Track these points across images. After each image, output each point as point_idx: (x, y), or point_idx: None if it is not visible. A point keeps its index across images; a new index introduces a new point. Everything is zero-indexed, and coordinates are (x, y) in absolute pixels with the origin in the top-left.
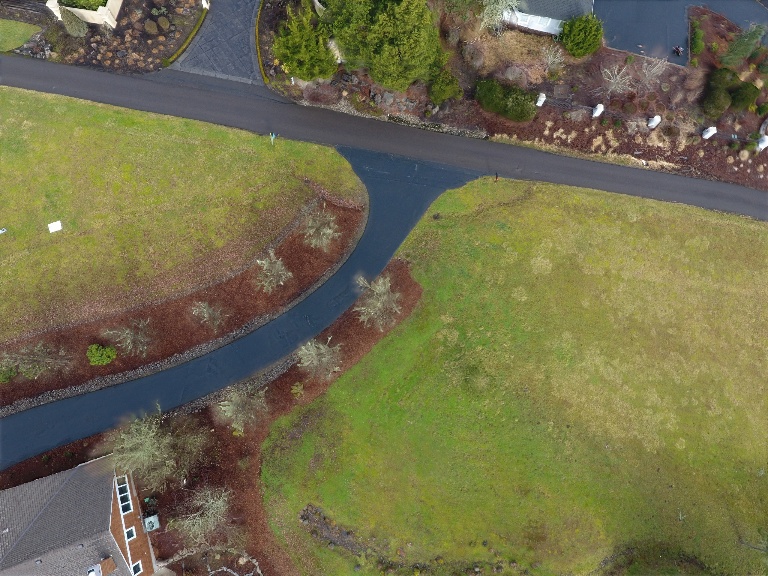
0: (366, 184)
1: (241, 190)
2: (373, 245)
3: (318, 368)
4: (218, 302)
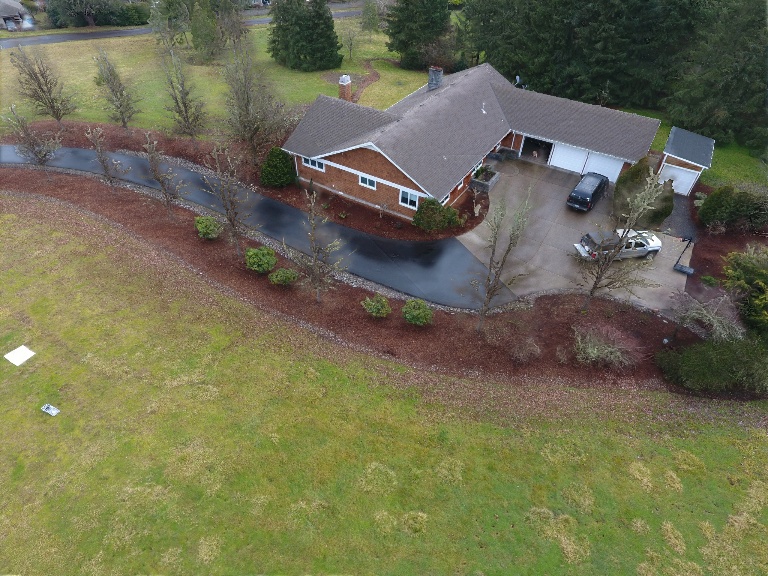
0: None
1: None
2: None
3: (141, 138)
4: (98, 198)
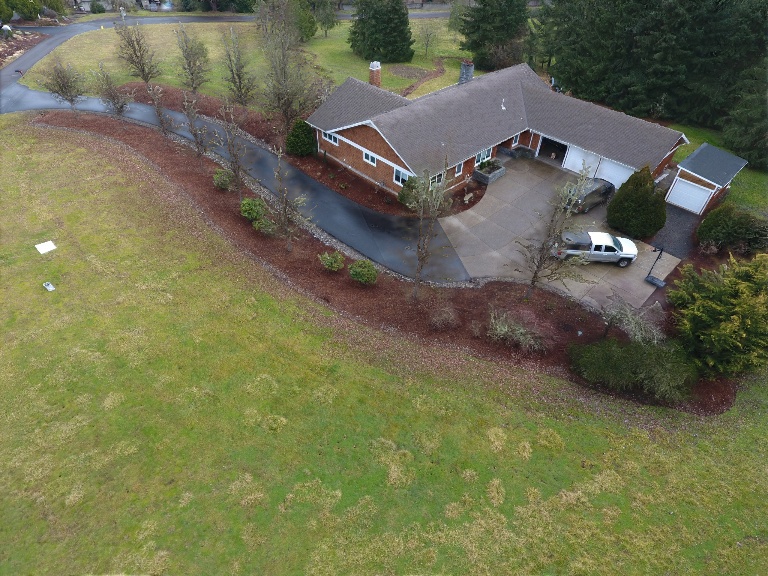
0: (14, 111)
1: (8, 152)
2: (86, 105)
3: (206, 104)
4: None
